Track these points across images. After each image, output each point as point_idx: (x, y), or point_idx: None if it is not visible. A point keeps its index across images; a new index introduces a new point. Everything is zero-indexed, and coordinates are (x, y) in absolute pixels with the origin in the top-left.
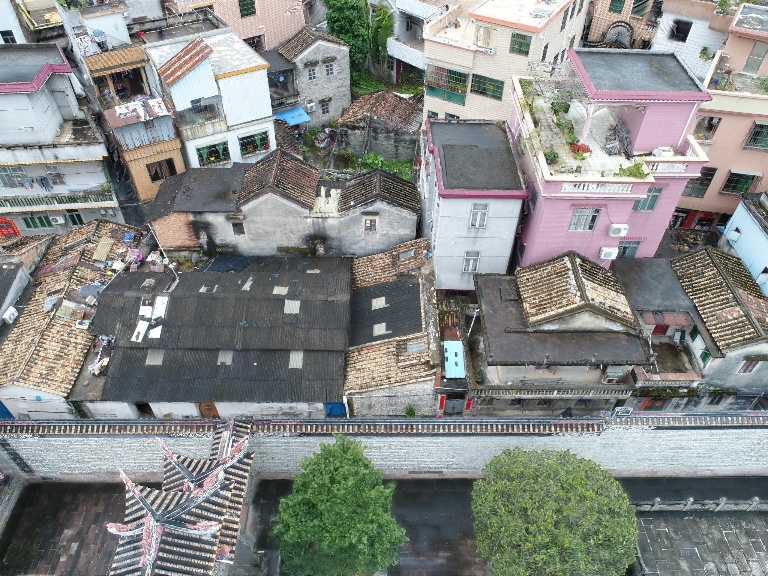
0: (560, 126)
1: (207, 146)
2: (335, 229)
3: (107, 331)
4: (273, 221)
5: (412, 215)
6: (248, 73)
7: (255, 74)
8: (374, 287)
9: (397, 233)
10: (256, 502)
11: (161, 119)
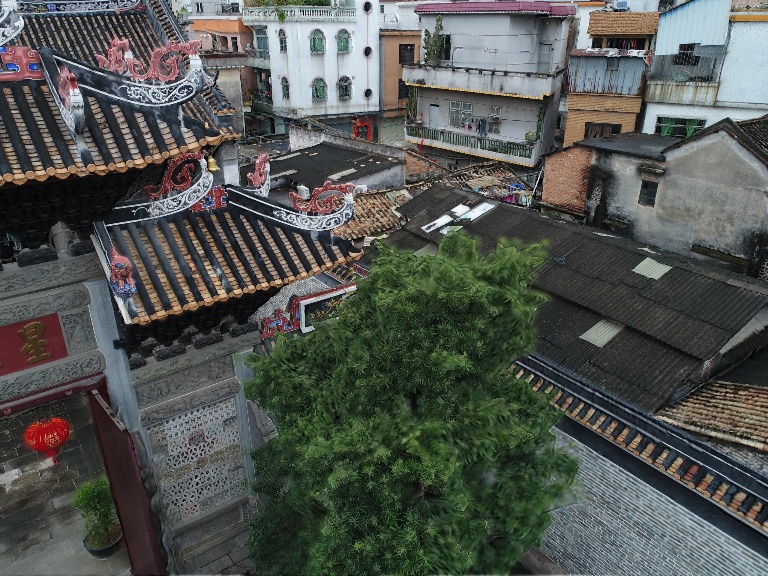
0: None
1: (673, 118)
2: None
3: (409, 213)
4: (707, 190)
5: None
6: None
7: None
8: None
9: None
10: None
11: (631, 62)
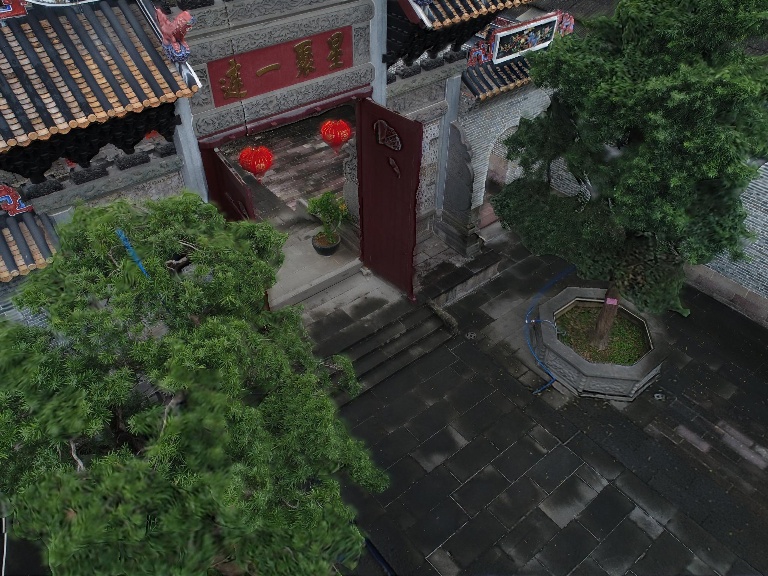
0: None
1: None
2: None
3: None
4: None
5: None
6: None
7: None
8: None
9: None
10: None
11: None
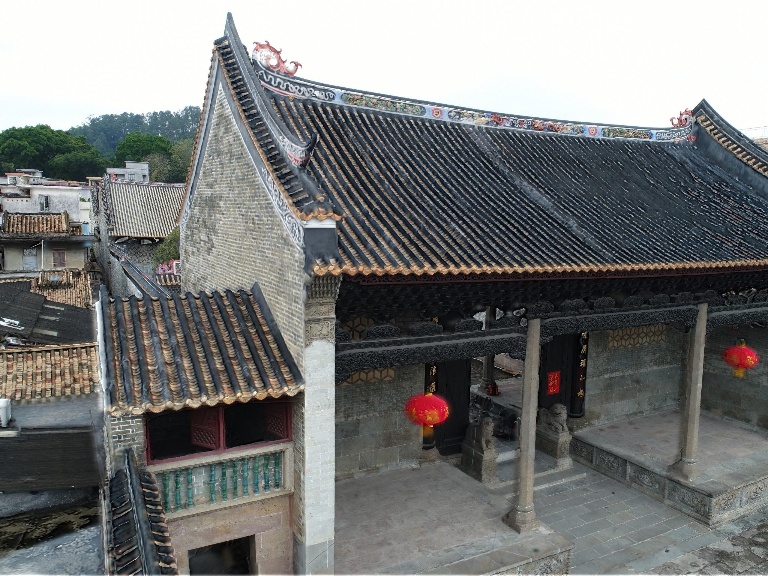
0: None
1: None
2: None
3: None
4: None
5: None
6: None
7: None
8: None
9: None
10: None
11: None
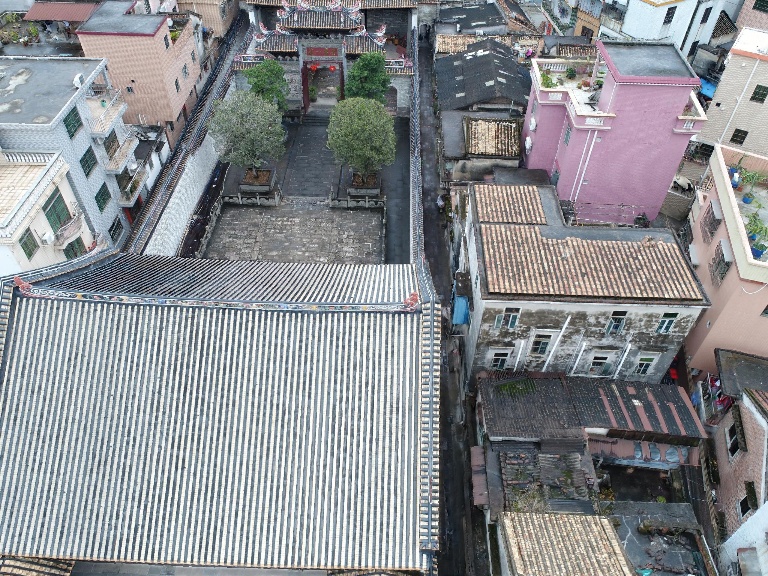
0: None
1: (605, 34)
2: None
3: None
4: None
5: None
6: (647, 4)
7: (650, 7)
8: None
9: None
10: (399, 117)
11: (599, 2)
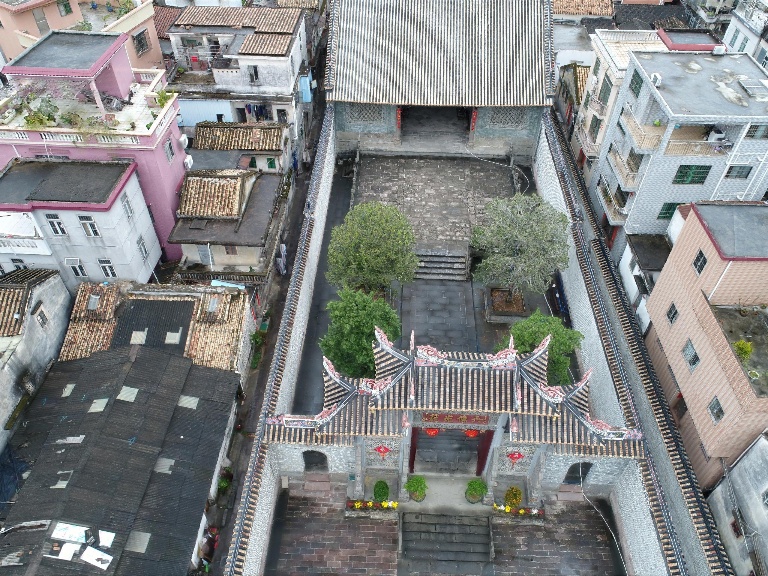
0: (71, 120)
1: None
2: (26, 353)
3: None
4: None
5: (56, 278)
6: None
7: None
8: (114, 341)
9: (59, 305)
10: None
11: None
